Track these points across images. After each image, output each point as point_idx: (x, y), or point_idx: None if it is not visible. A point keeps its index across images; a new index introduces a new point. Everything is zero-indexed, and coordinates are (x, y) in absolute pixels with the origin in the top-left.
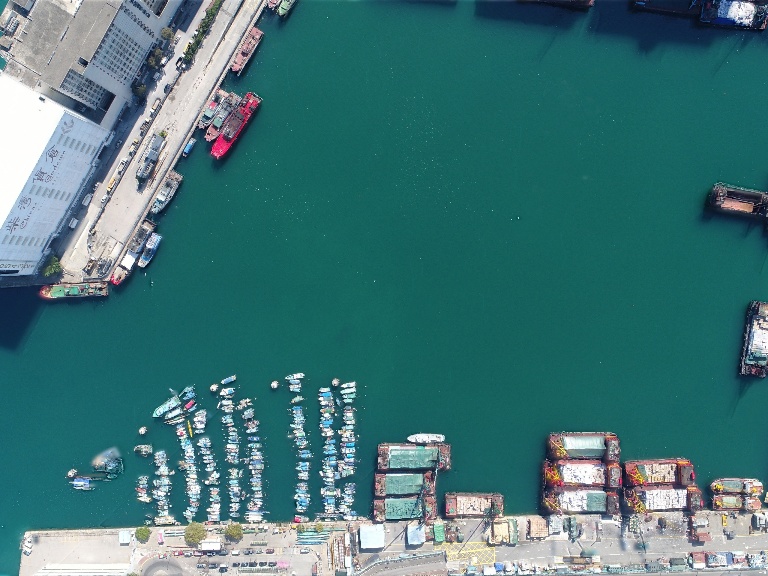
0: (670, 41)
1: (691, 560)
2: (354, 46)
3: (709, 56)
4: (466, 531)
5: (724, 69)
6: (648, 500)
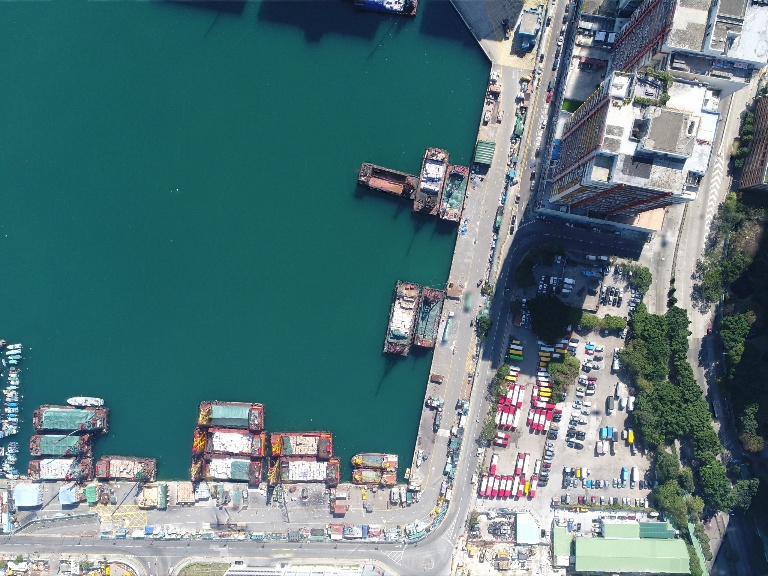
0: (328, 22)
1: (329, 531)
2: (28, 14)
3: (364, 39)
4: (120, 494)
5: (378, 52)
6: (291, 471)
